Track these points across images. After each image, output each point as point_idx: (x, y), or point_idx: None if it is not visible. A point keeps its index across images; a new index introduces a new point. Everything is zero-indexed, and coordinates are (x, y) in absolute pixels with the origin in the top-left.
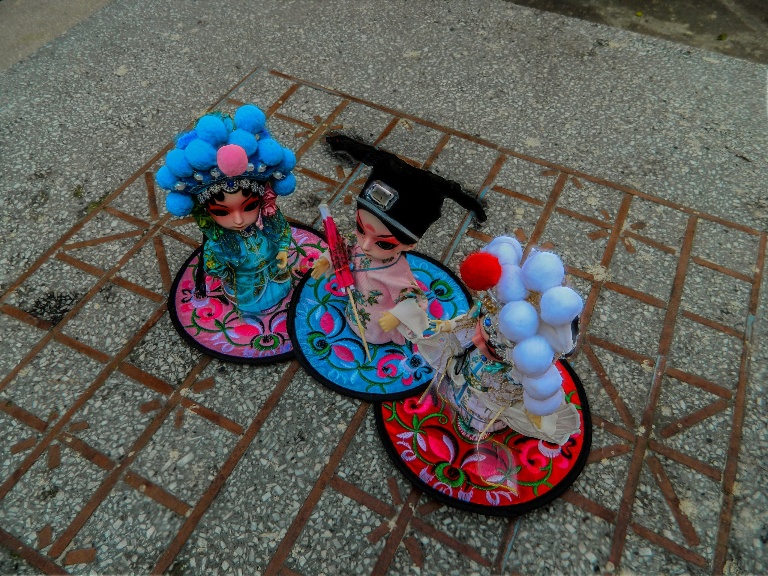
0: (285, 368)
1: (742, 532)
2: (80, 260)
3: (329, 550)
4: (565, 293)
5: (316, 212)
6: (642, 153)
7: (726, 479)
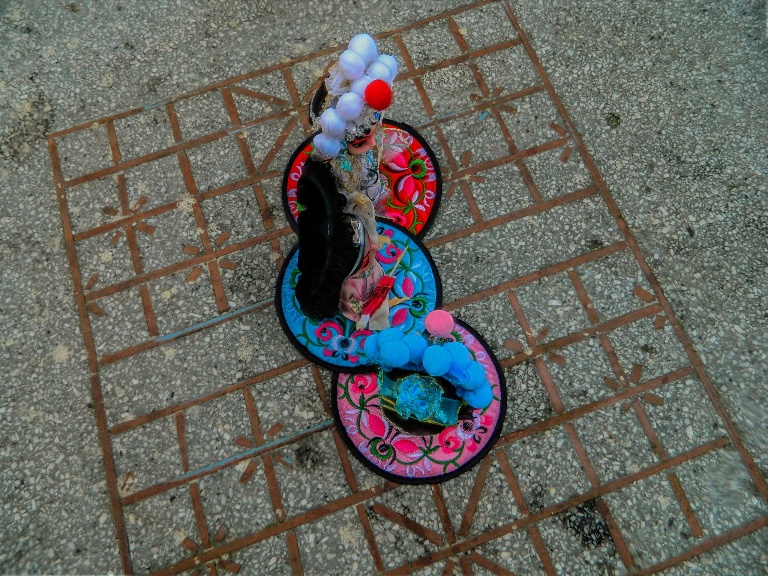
0: (452, 313)
1: (309, 48)
2: (543, 567)
3: (509, 192)
4: (361, 41)
5: (313, 439)
6: (6, 261)
7: (285, 67)
